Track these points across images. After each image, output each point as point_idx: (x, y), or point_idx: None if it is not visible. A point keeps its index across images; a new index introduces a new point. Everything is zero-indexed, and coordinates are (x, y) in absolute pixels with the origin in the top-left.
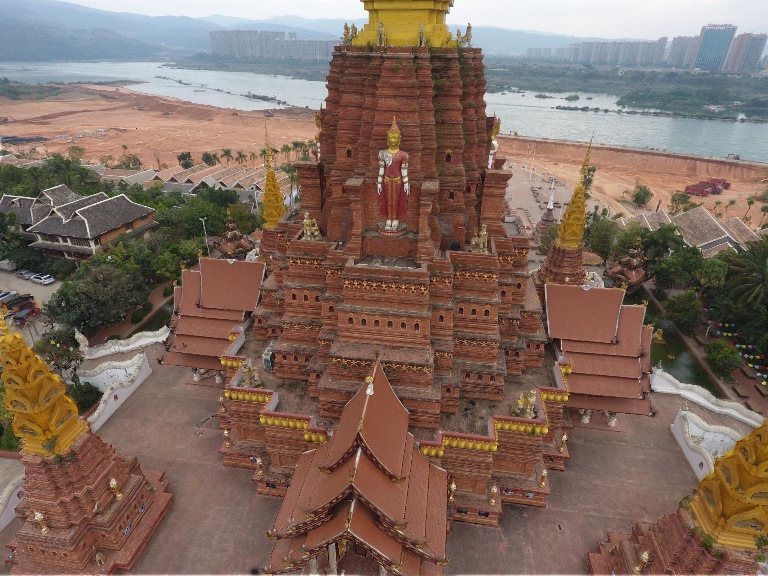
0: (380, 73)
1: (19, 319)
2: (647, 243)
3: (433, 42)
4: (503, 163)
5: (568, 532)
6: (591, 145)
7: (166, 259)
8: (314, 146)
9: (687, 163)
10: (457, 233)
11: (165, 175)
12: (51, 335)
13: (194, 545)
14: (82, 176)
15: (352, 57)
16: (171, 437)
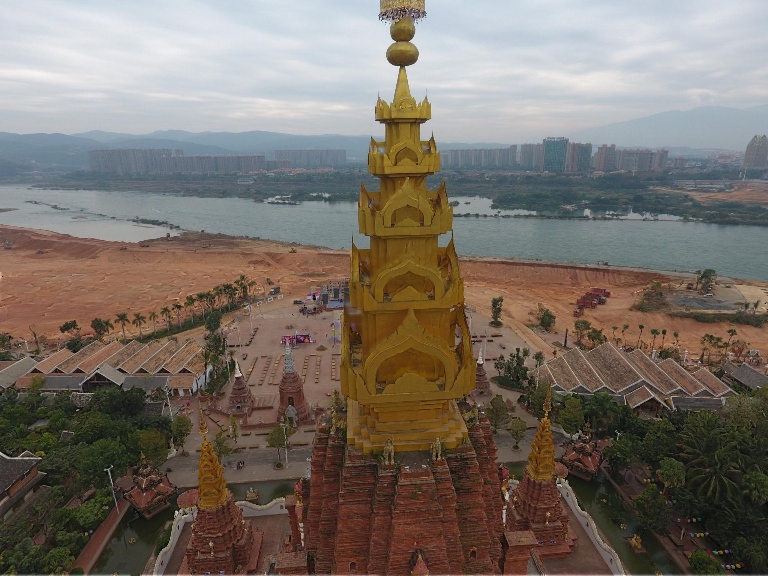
0: (392, 492)
1: None
2: (588, 414)
3: (447, 444)
4: None
5: None
6: (485, 260)
7: (62, 554)
8: (221, 294)
9: (569, 272)
10: None
11: (46, 365)
12: None
13: None
14: None
15: (352, 467)
16: None
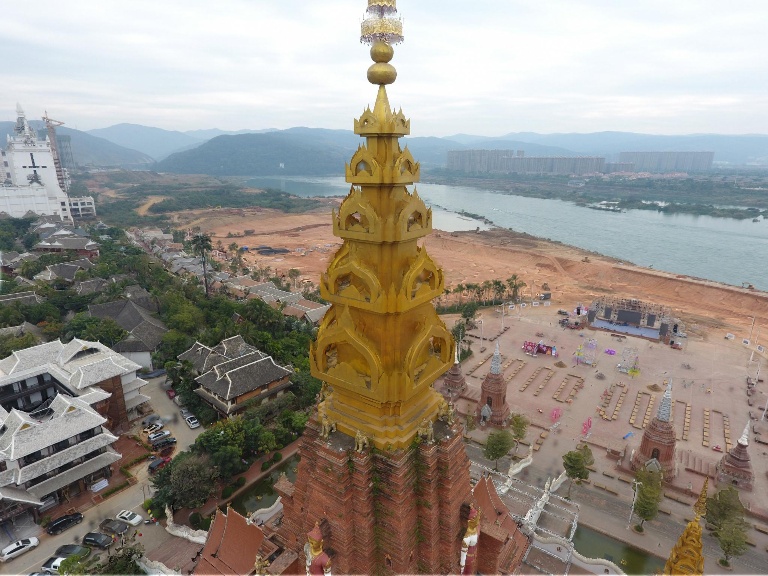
0: None
1: (151, 468)
2: None
3: (376, 443)
4: (500, 544)
5: None
6: None
7: (269, 437)
8: (488, 288)
9: None
10: None
11: None
12: (152, 502)
13: None
14: (268, 316)
15: (310, 428)
16: None
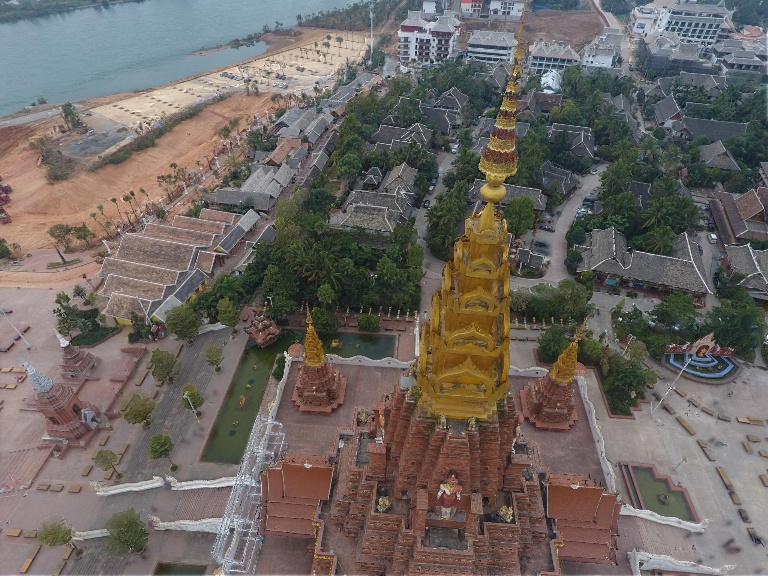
0: None
1: None
2: None
3: None
4: None
5: (523, 433)
6: None
7: None
8: None
9: None
10: None
11: None
12: None
13: None
14: None
15: None
16: None
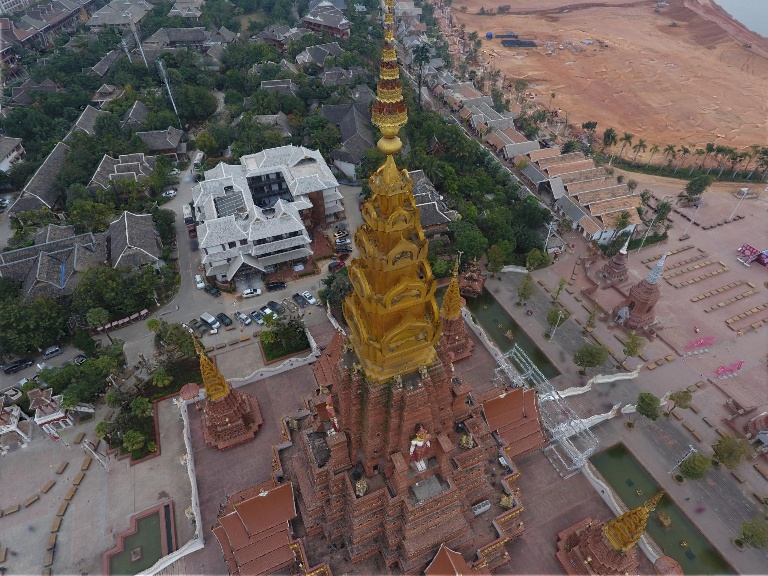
0: None
1: (330, 267)
2: None
3: (365, 373)
4: None
5: None
6: None
7: None
8: (749, 156)
9: None
10: (365, 467)
11: (537, 155)
12: (322, 294)
13: (240, 464)
14: (460, 149)
15: None
16: (287, 406)
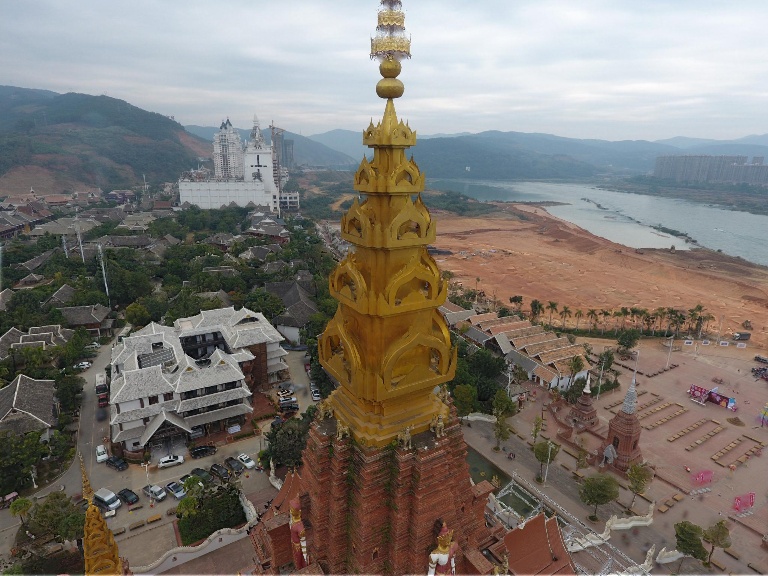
0: None
1: (273, 426)
2: None
3: (355, 436)
4: (480, 575)
5: None
6: None
7: None
8: (660, 316)
9: None
10: None
11: (476, 319)
12: None
13: None
14: None
15: None
16: None
